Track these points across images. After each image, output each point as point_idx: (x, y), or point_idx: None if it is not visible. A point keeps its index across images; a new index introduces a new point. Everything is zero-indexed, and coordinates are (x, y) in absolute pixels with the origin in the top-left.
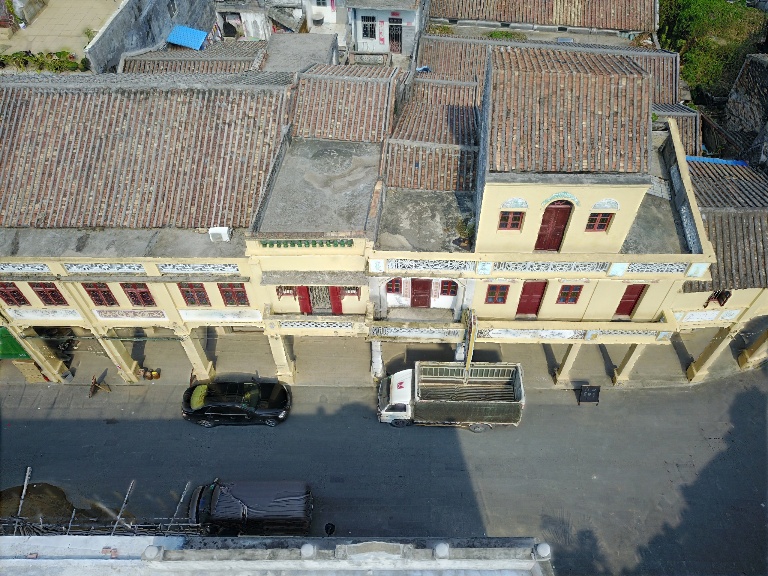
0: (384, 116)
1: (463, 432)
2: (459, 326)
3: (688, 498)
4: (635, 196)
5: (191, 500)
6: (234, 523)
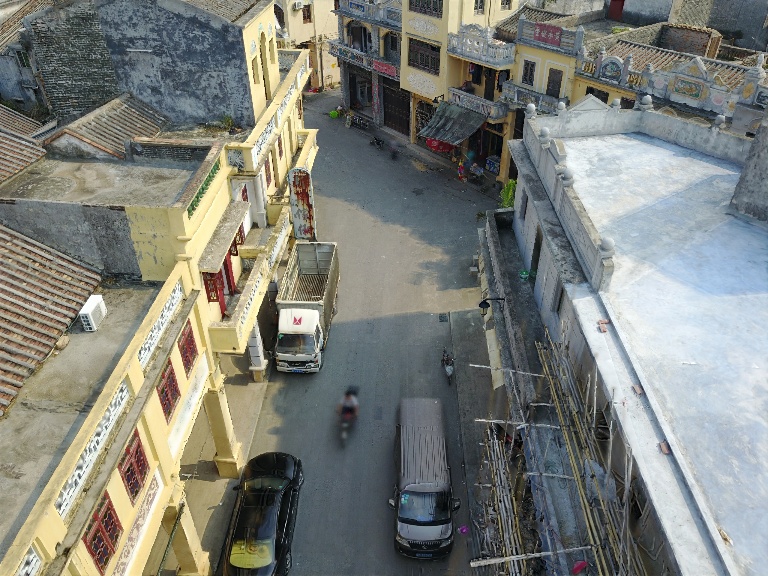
0: (8, 136)
1: (335, 321)
2: (286, 208)
3: (401, 222)
4: (272, 15)
5: (416, 540)
6: (442, 486)
